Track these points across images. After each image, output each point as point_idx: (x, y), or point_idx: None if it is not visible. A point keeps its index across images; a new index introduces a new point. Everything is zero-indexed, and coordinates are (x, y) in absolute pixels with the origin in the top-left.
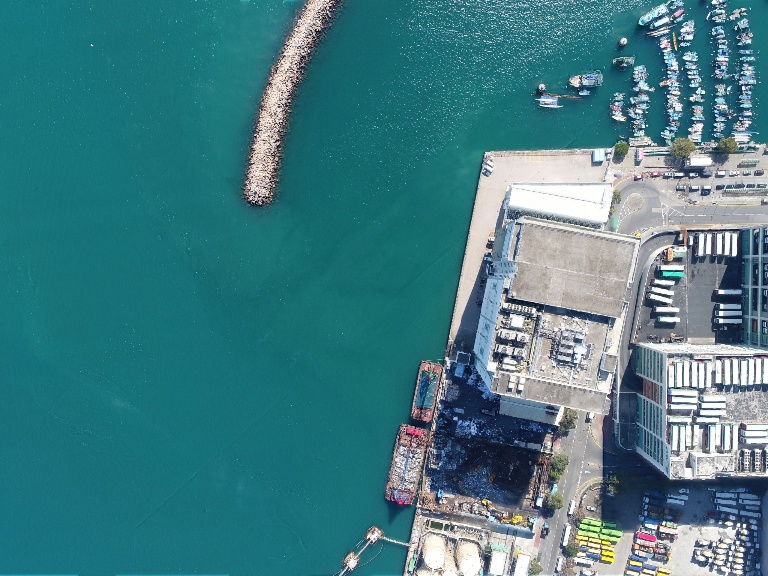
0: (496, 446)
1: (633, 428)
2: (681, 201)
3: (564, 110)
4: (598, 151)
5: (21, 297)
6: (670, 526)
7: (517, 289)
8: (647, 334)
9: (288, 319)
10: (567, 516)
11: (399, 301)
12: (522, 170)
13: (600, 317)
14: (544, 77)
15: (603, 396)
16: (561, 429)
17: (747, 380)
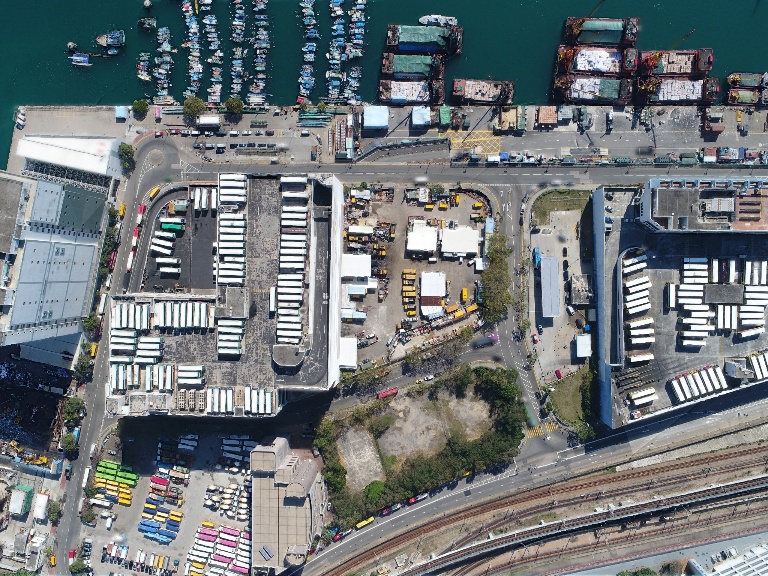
0: (24, 390)
1: None
2: (198, 158)
3: (94, 68)
4: (118, 108)
5: None
6: (180, 470)
7: None
8: (154, 284)
9: None
10: (90, 459)
11: None
12: (52, 124)
13: None
14: (76, 36)
15: None
16: (75, 374)
17: (180, 323)
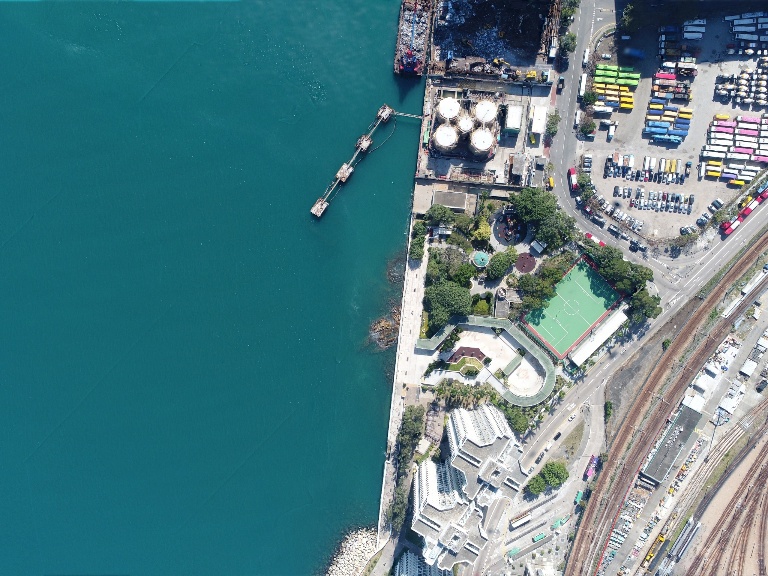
0: (504, 1)
1: None
2: None
3: None
4: None
5: None
6: (689, 61)
7: None
8: None
9: None
10: (582, 68)
11: None
12: None
13: None
14: None
15: None
16: None
17: None
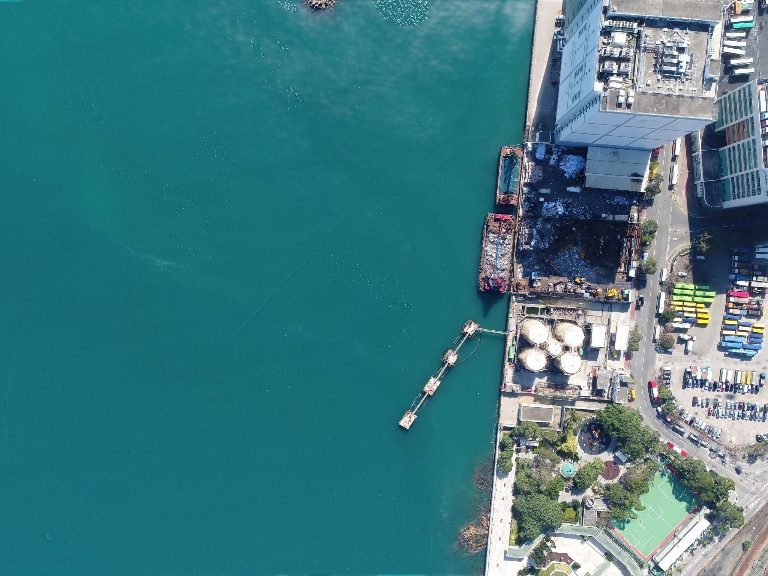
0: (584, 223)
1: (717, 185)
2: None
3: None
4: None
5: (85, 130)
6: (761, 280)
7: (617, 4)
8: (722, 90)
9: (363, 122)
10: (659, 285)
11: (473, 91)
12: None
13: (699, 26)
14: None
15: (711, 101)
16: (648, 194)
17: None
